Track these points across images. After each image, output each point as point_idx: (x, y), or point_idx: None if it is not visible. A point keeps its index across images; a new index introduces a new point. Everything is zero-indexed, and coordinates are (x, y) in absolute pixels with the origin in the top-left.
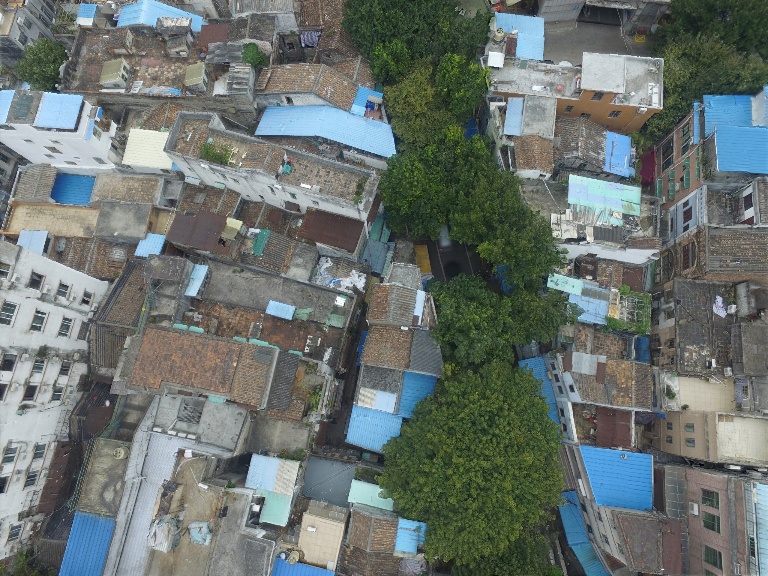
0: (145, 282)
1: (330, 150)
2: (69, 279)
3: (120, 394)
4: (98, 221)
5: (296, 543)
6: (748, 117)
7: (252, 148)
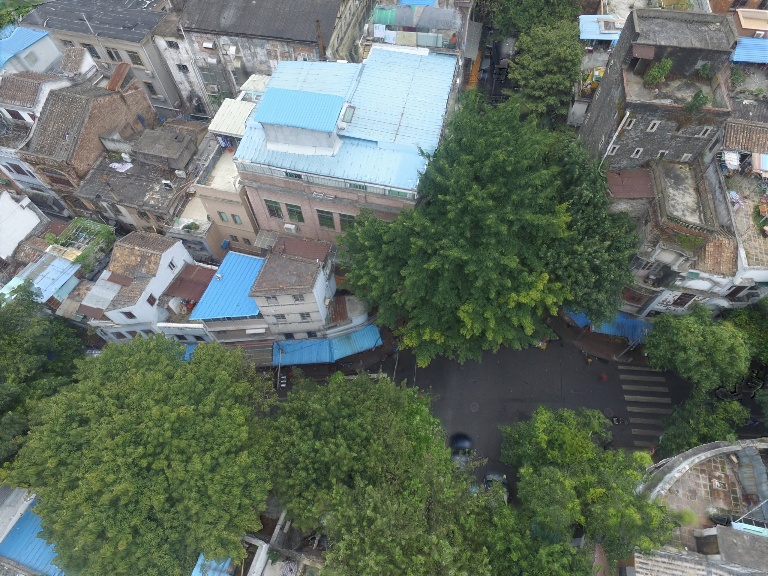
0: None
1: None
2: None
3: None
4: None
5: None
6: None
7: None
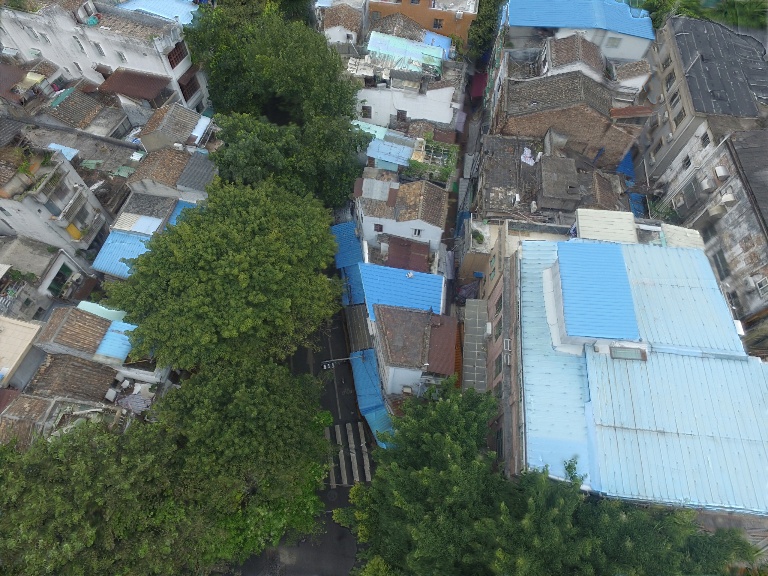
0: None
1: None
2: None
3: None
4: None
5: None
6: None
7: None
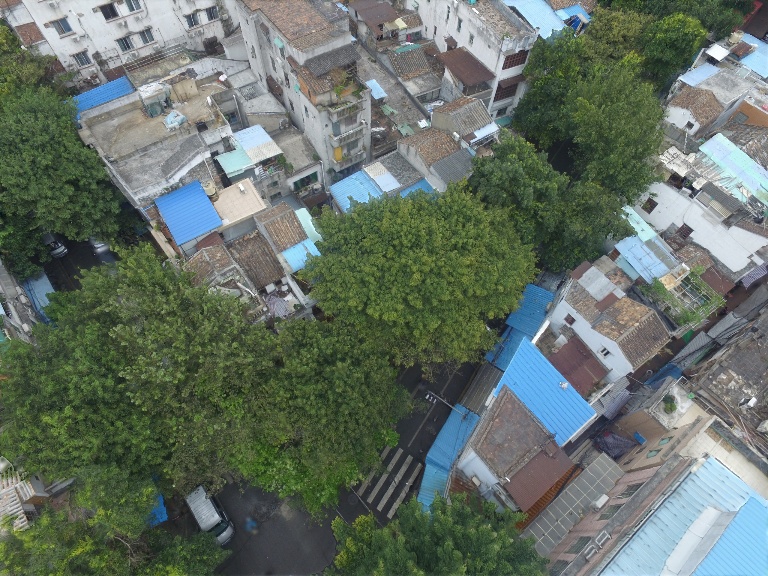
0: None
1: None
2: None
3: (224, 46)
4: None
5: None
6: None
7: None
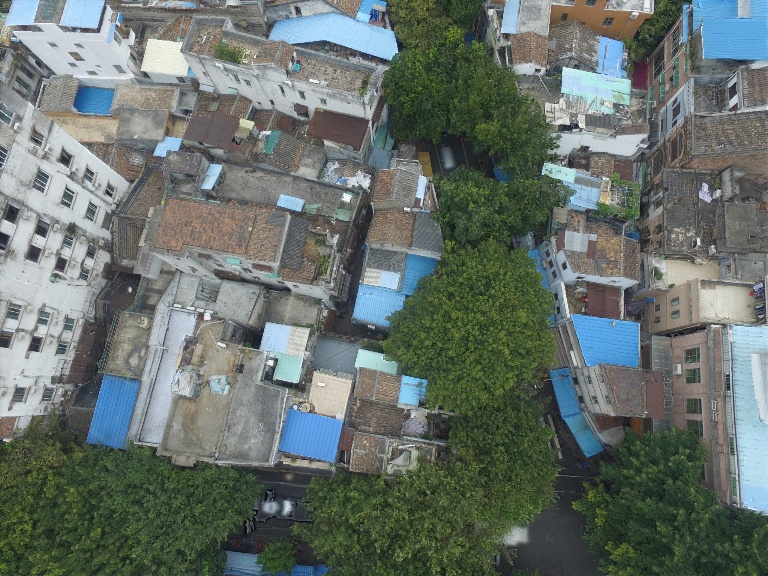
0: (164, 176)
1: (337, 56)
2: (94, 166)
3: (142, 274)
4: (119, 126)
5: (307, 399)
6: (734, 14)
7: (264, 46)
